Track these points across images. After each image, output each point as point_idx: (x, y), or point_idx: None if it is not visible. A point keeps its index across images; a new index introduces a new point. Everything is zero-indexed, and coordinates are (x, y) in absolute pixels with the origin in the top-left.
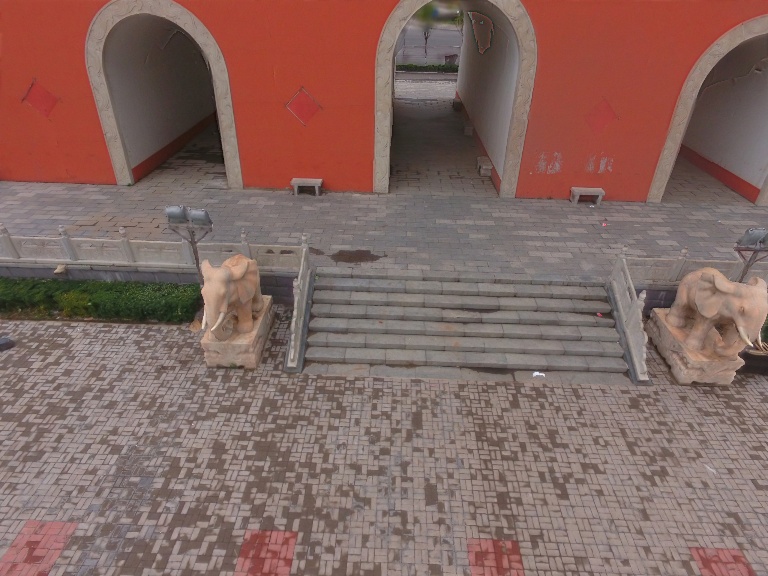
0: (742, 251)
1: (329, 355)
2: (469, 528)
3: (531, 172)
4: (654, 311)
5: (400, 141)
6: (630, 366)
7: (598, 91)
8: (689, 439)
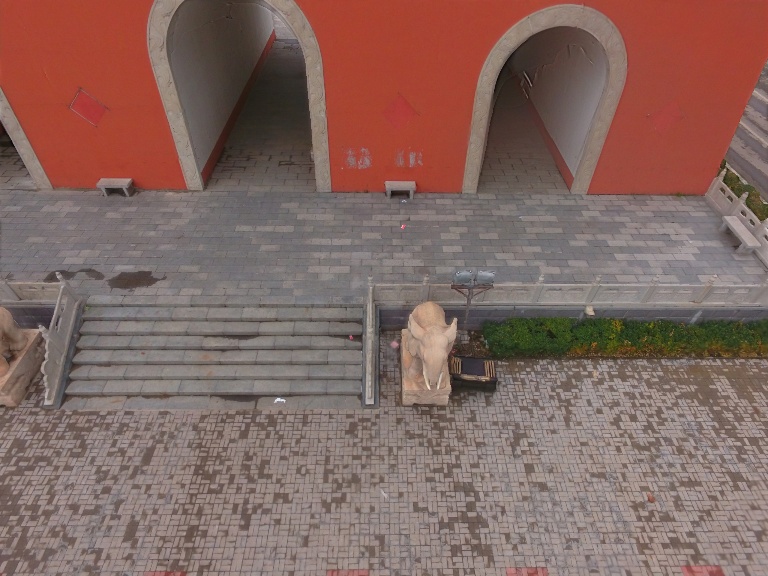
0: (458, 288)
1: (88, 390)
2: (150, 562)
3: (342, 167)
4: (401, 333)
5: (250, 110)
6: (363, 390)
7: (393, 87)
8: (381, 464)
